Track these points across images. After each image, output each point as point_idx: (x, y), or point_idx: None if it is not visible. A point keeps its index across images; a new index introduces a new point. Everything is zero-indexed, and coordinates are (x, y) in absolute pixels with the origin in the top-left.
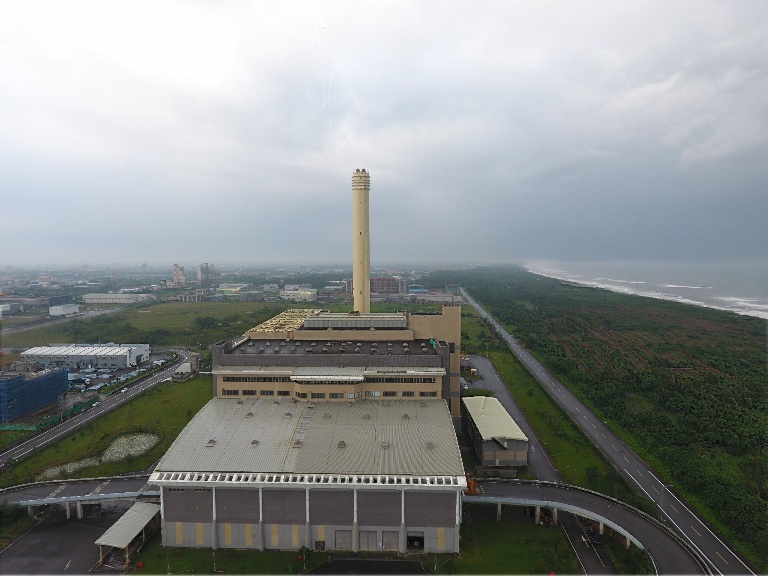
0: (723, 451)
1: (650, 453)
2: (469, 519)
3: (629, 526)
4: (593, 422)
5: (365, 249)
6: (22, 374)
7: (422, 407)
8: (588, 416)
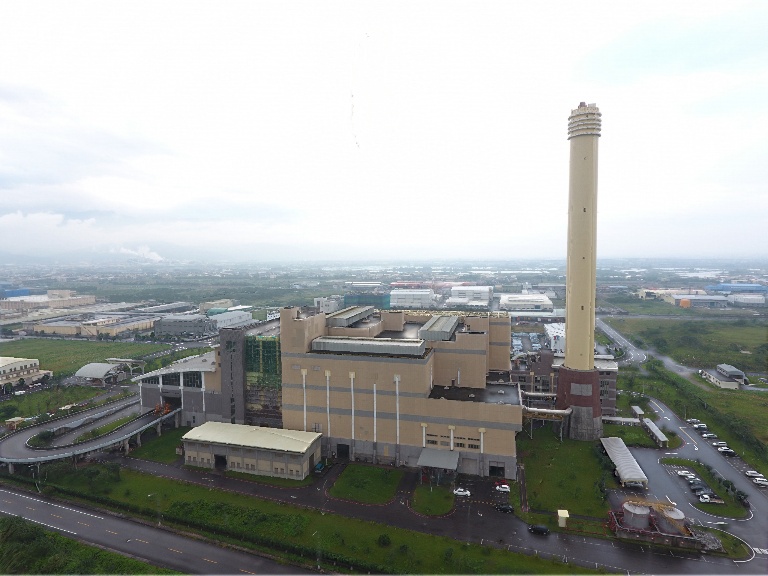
0: None
1: None
2: None
3: (55, 451)
4: (222, 567)
5: (571, 236)
6: None
7: None
8: None
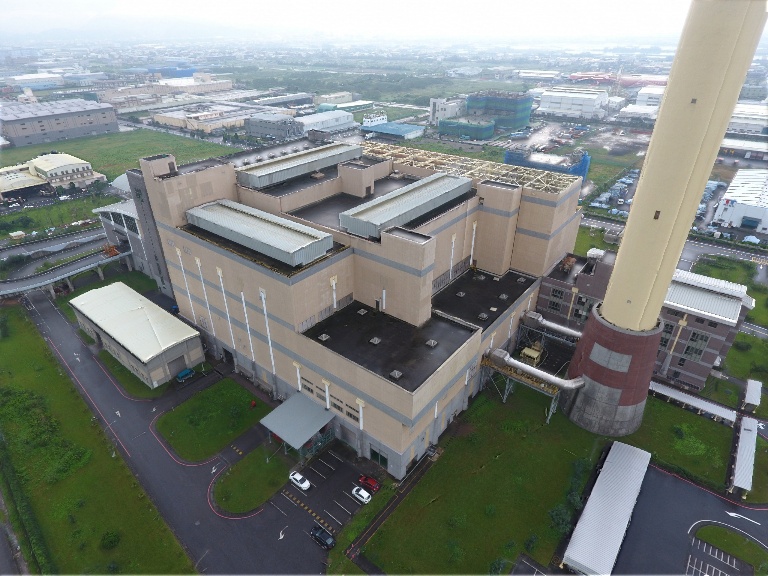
0: None
1: None
2: (116, 268)
3: None
4: None
5: (683, 41)
6: (521, 152)
7: None
8: None
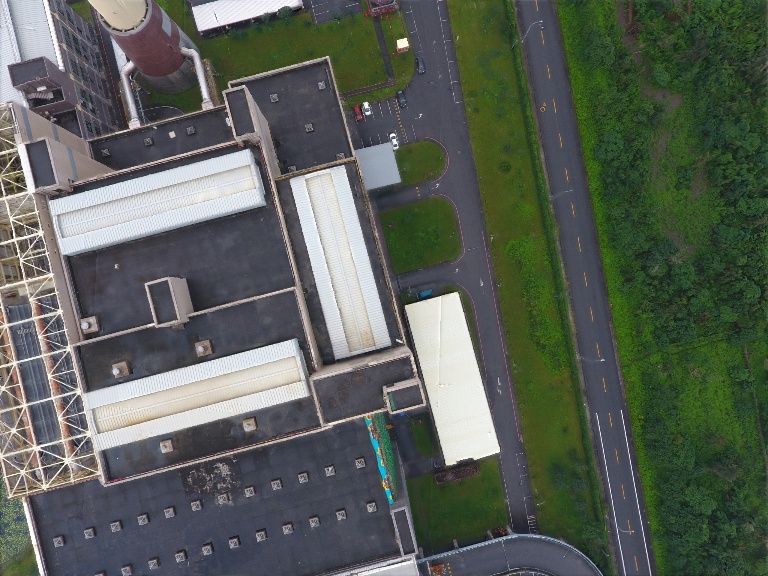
0: (723, 337)
1: (636, 360)
2: None
3: None
4: (587, 264)
5: None
6: None
7: None
8: (584, 239)
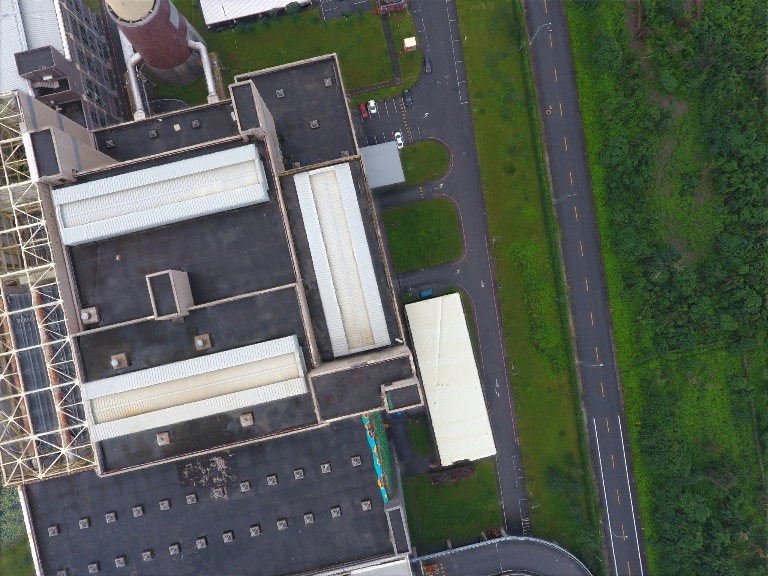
0: (723, 345)
1: (635, 366)
2: None
3: None
4: (589, 269)
5: None
6: None
7: (376, 569)
8: (586, 243)
